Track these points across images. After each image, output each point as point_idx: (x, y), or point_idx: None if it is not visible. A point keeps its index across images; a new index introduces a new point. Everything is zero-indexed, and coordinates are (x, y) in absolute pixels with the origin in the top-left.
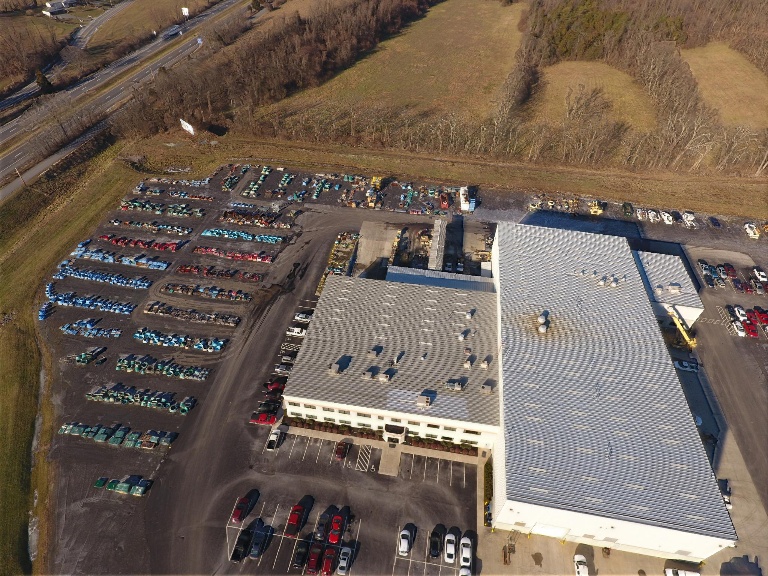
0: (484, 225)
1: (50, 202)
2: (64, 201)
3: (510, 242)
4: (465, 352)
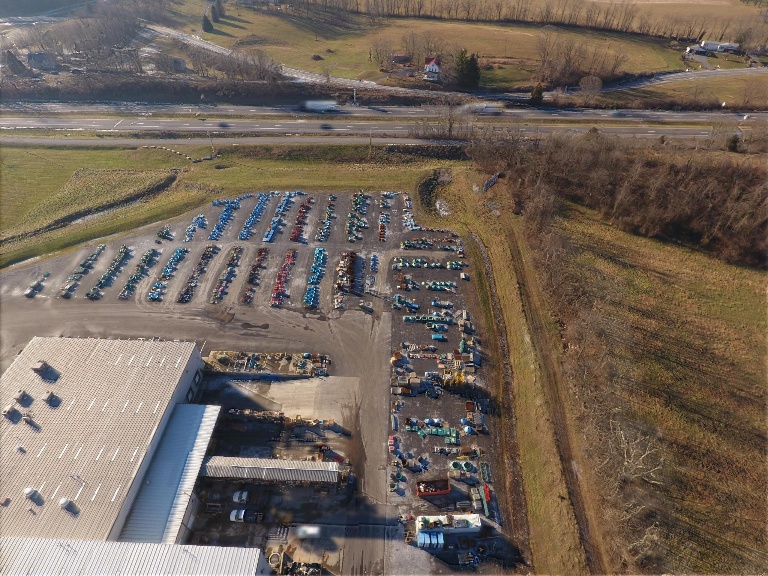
0: (372, 567)
1: (363, 163)
2: (367, 168)
3: (192, 568)
4: (3, 497)
